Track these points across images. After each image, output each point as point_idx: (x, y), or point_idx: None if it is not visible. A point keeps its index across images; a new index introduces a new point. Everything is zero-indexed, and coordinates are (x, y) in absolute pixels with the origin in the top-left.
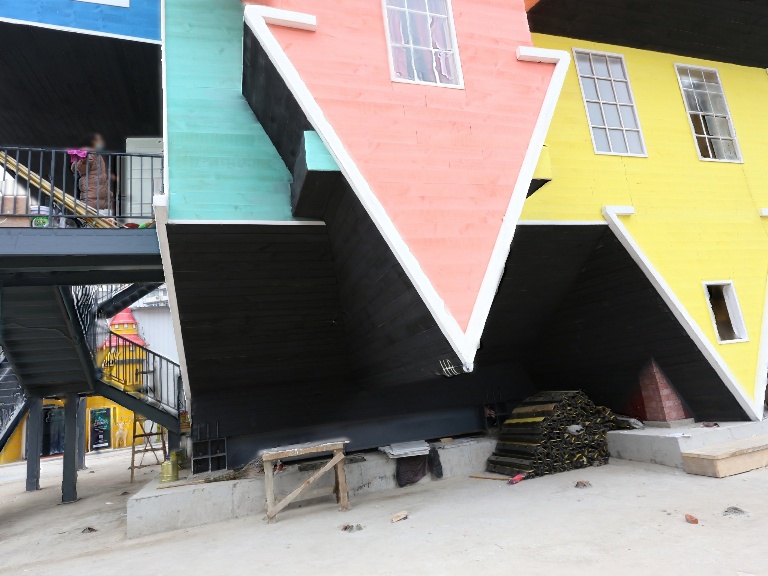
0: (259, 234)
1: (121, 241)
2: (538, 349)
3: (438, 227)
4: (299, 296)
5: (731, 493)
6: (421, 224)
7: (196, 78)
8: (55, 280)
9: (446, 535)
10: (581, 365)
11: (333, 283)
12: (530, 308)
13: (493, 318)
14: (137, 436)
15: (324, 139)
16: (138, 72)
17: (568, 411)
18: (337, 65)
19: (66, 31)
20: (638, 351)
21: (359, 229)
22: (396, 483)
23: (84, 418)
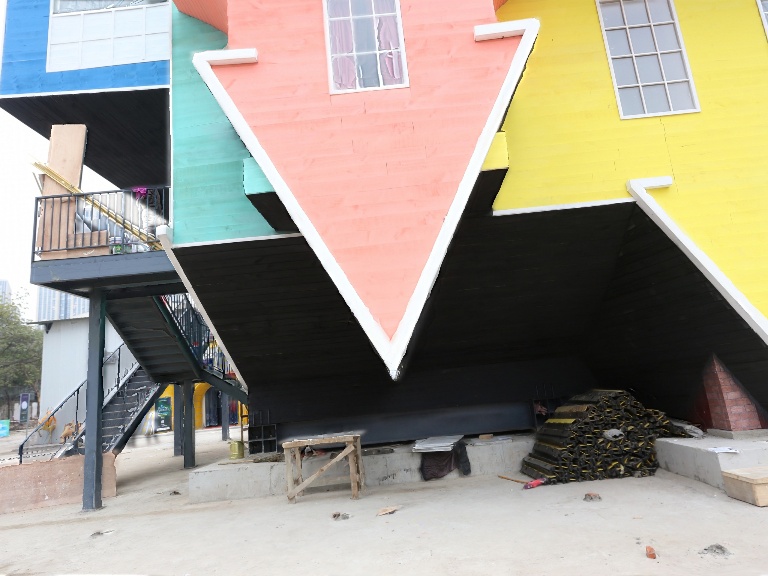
0: (250, 249)
1: None
2: (589, 342)
3: (371, 234)
4: (307, 300)
5: (746, 527)
6: (353, 233)
7: (196, 118)
8: (149, 292)
9: (403, 534)
10: (638, 360)
11: (334, 286)
12: (566, 299)
13: (524, 311)
14: (244, 416)
15: (258, 164)
16: None
17: (607, 413)
18: (277, 90)
19: (130, 91)
20: (696, 346)
21: None
22: (421, 476)
23: (226, 398)
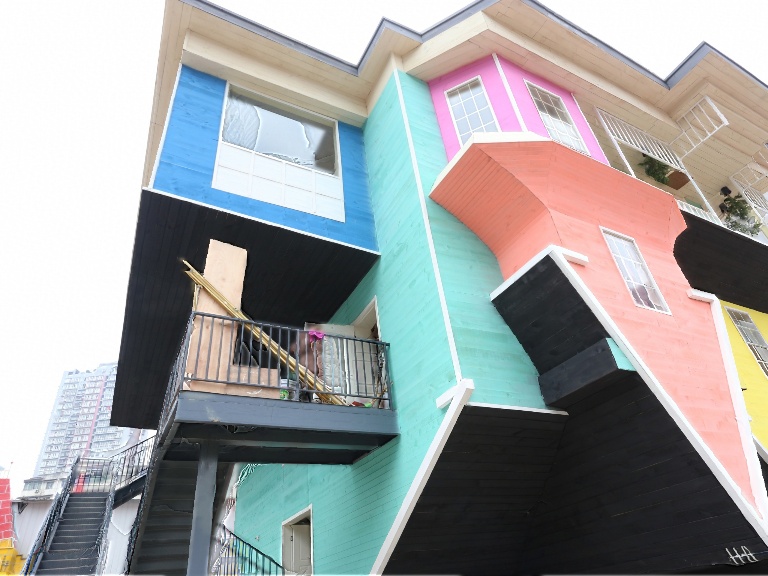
0: (520, 420)
1: (354, 419)
2: None
3: (705, 422)
4: (517, 483)
5: None
6: (695, 419)
7: (460, 286)
8: (235, 456)
9: None
10: (716, 568)
11: (547, 471)
12: None
13: None
14: None
15: (623, 345)
16: (333, 270)
17: None
18: (604, 291)
19: (306, 235)
20: None
21: (636, 420)
22: None
23: None
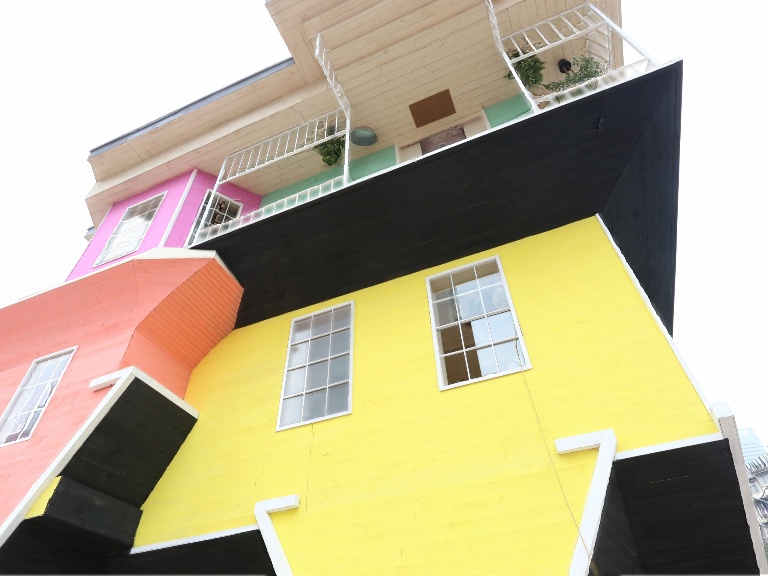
0: None
1: None
2: None
3: None
4: None
5: None
6: None
7: None
8: None
9: None
10: None
11: None
12: None
13: None
14: None
15: None
16: None
17: None
18: None
19: None
20: None
21: None
22: None
23: None
